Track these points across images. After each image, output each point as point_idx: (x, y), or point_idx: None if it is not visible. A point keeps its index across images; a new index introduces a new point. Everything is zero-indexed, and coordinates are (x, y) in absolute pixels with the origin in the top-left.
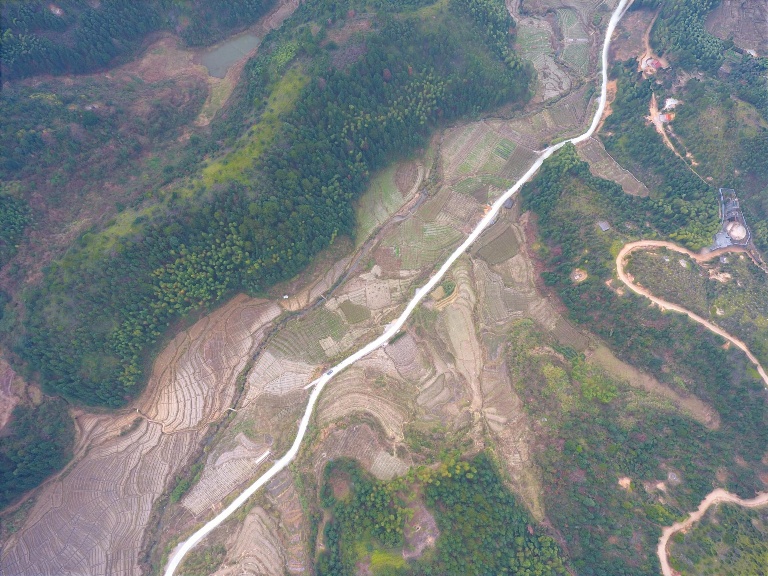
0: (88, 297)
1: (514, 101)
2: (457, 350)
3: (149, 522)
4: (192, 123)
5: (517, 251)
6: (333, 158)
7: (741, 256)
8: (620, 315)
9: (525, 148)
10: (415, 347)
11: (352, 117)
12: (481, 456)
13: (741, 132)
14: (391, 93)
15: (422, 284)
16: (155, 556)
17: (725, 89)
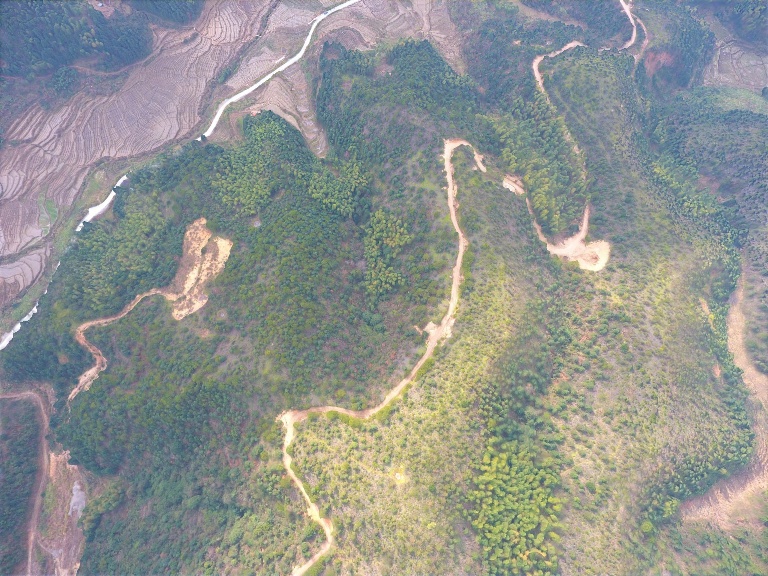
0: None
1: None
2: None
3: (204, 92)
4: None
5: None
6: None
7: None
8: None
9: None
10: (385, 1)
11: None
12: None
13: None
14: None
15: None
16: (209, 110)
17: None
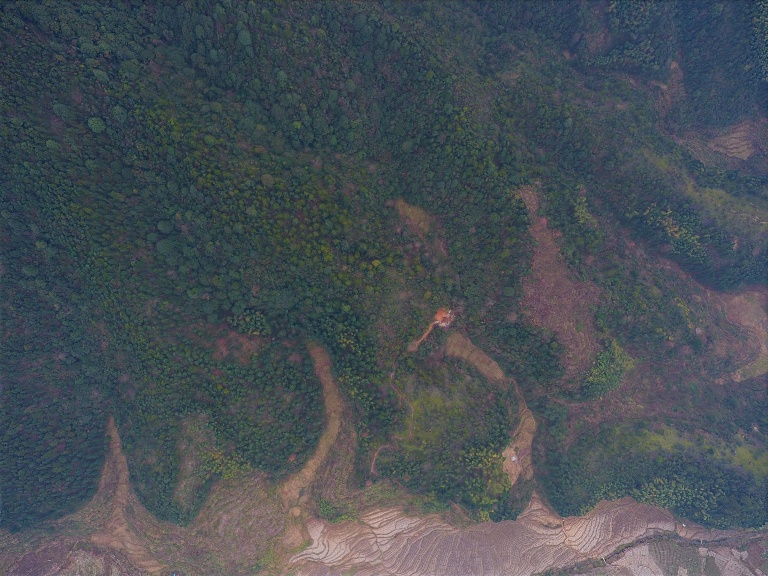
0: (616, 466)
1: None
2: None
3: None
4: (731, 374)
5: None
6: None
7: None
8: None
9: None
10: None
11: None
12: None
13: None
14: None
15: None
16: None
17: None
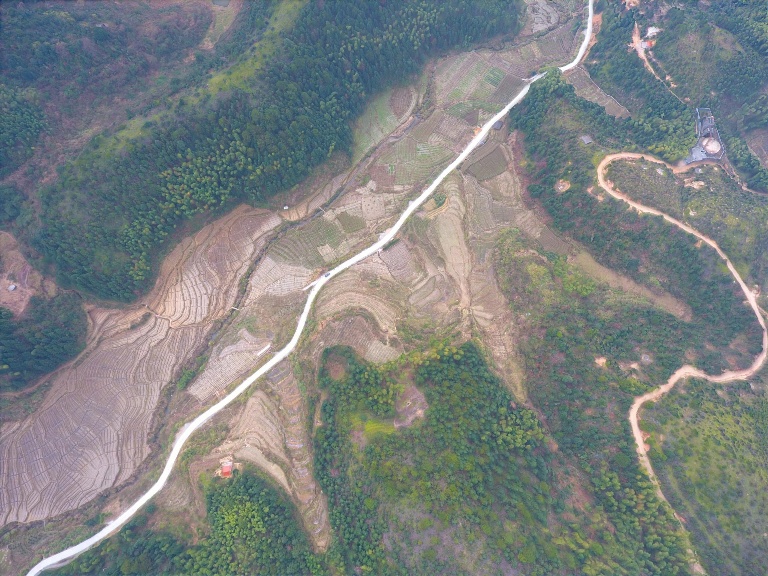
0: (100, 194)
1: (504, 33)
2: (447, 254)
3: (157, 406)
4: (197, 46)
5: (505, 168)
6: (331, 75)
7: (715, 168)
8: (600, 220)
9: (514, 76)
10: (408, 253)
11: (349, 38)
12: (468, 342)
13: (717, 54)
14: (386, 17)
15: (415, 197)
16: (163, 436)
17: (703, 16)
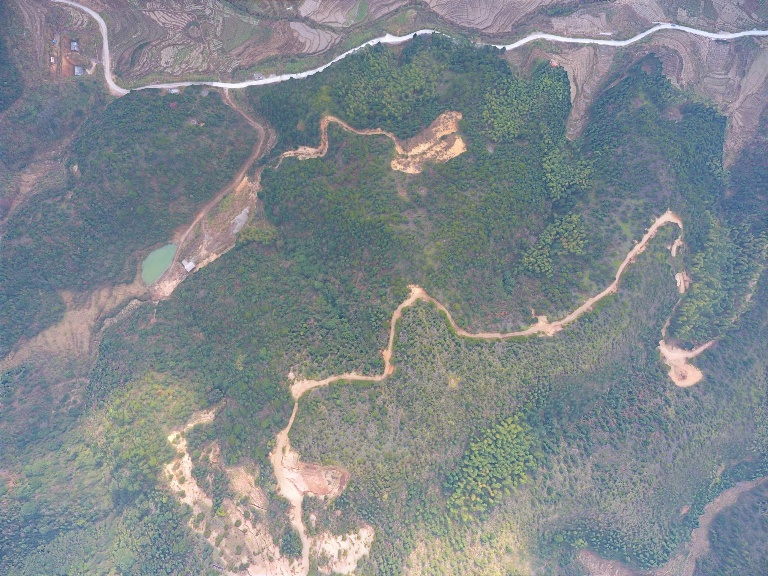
0: None
1: None
2: (750, 73)
3: (531, 12)
4: None
5: None
6: None
7: None
8: None
9: None
10: (726, 55)
11: None
12: None
13: None
14: None
15: (760, 28)
16: (523, 29)
17: None
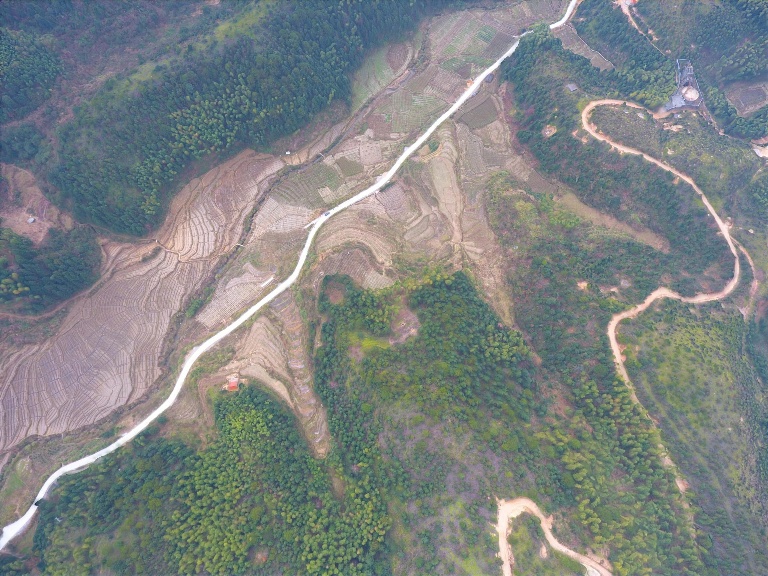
0: (114, 131)
1: None
2: (440, 195)
3: (167, 333)
4: (203, 2)
5: (496, 117)
6: (331, 27)
7: (693, 114)
8: (584, 161)
9: (505, 33)
10: (403, 195)
11: None
12: None
13: (696, 8)
14: None
15: (410, 143)
16: (173, 359)
17: None
